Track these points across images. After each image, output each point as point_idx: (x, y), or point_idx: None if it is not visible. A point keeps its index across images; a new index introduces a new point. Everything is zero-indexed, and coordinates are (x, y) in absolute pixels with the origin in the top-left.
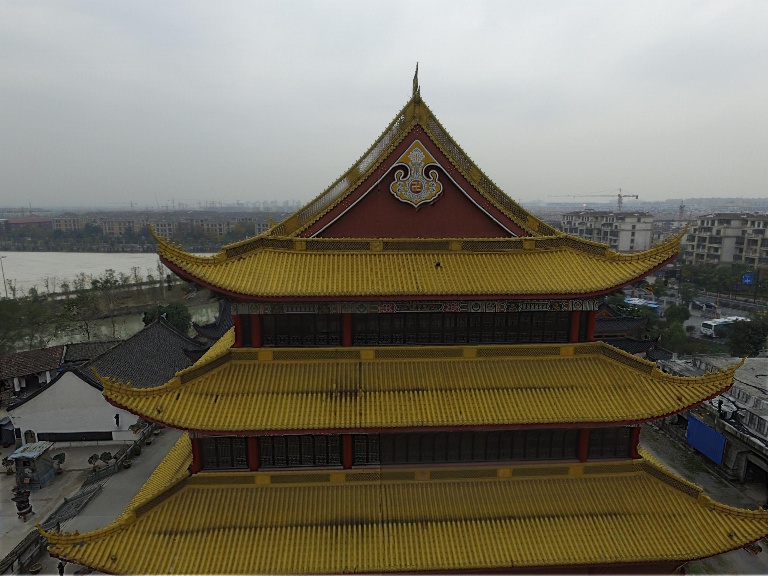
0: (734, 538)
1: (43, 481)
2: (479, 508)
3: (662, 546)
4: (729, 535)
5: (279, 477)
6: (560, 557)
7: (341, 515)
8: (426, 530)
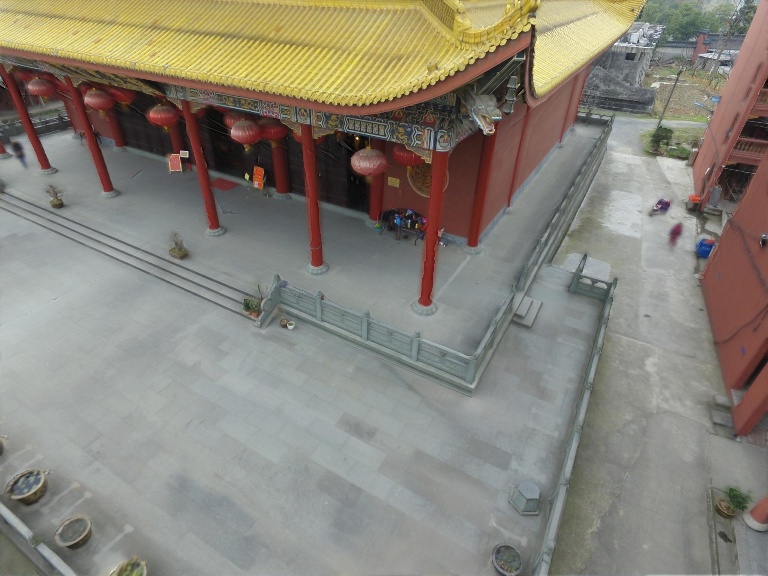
0: (635, 11)
1: None
2: (567, 15)
3: None
4: (632, 10)
5: None
6: None
7: None
8: None
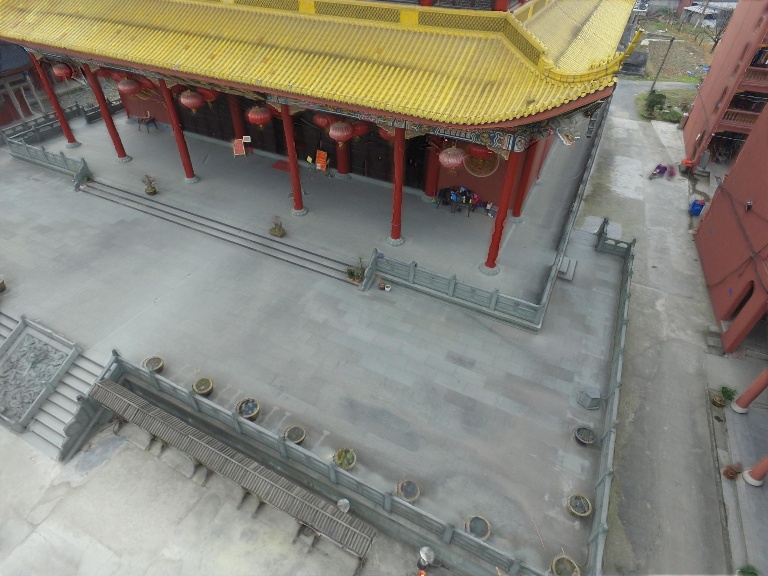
0: None
1: None
2: (586, 6)
3: (626, 5)
4: None
5: (535, 5)
6: (625, 19)
7: (569, 29)
8: (594, 24)
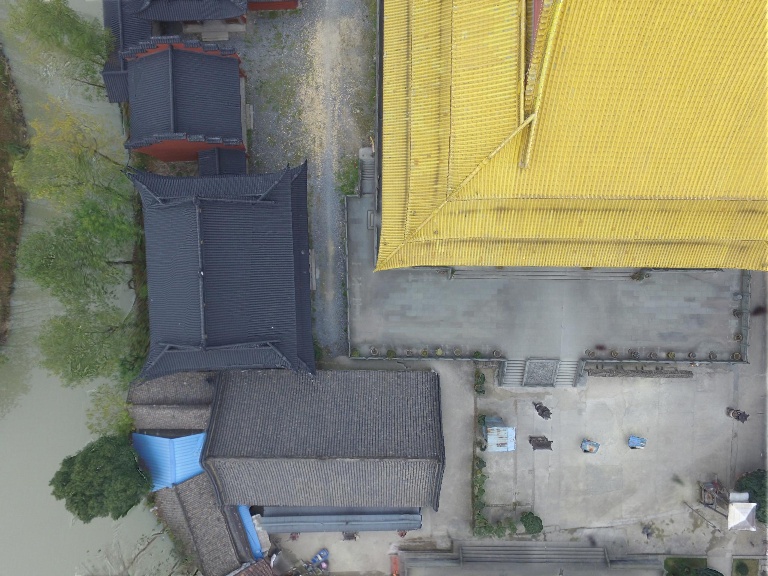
0: None
1: (498, 420)
2: None
3: None
4: None
5: None
6: None
7: None
8: None
